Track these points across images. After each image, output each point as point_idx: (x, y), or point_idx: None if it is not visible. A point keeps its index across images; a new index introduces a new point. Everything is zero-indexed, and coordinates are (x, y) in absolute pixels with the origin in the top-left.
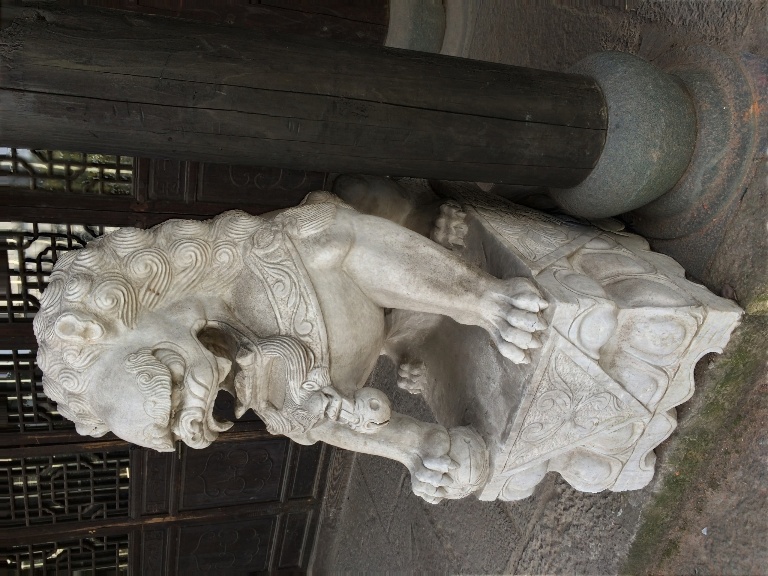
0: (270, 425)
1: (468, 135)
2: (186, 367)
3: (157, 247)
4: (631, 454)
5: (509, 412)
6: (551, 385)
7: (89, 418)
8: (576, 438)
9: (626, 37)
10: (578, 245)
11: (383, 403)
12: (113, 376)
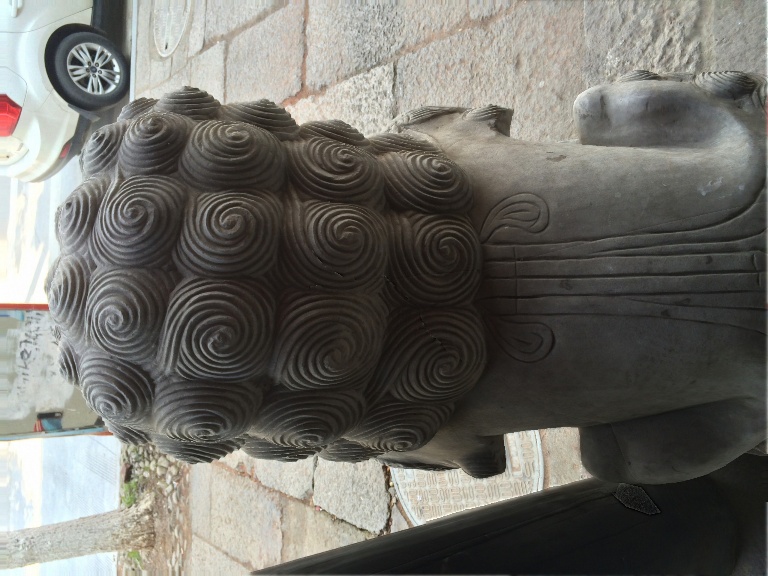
0: None
1: None
2: None
3: None
4: None
5: None
6: None
7: None
8: None
9: None
10: None
11: None
12: None
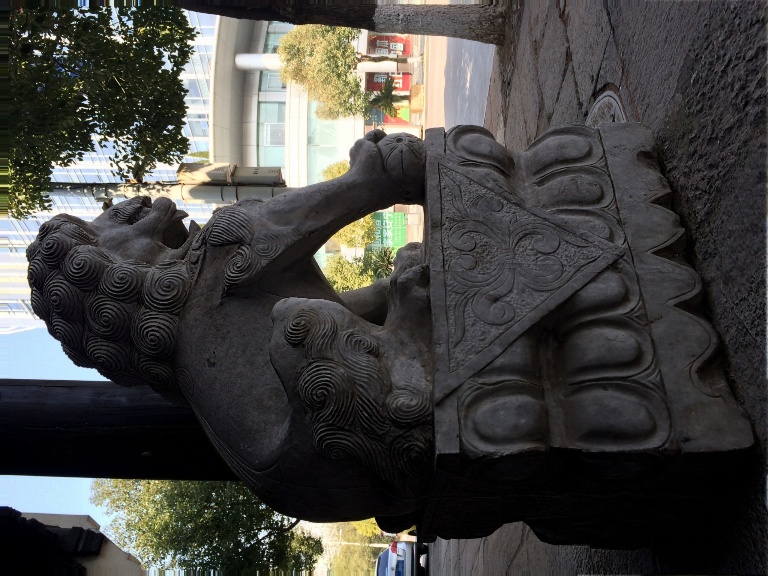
0: None
1: None
2: None
3: None
4: None
5: None
6: None
7: None
8: None
9: (599, 575)
10: None
11: None
12: None
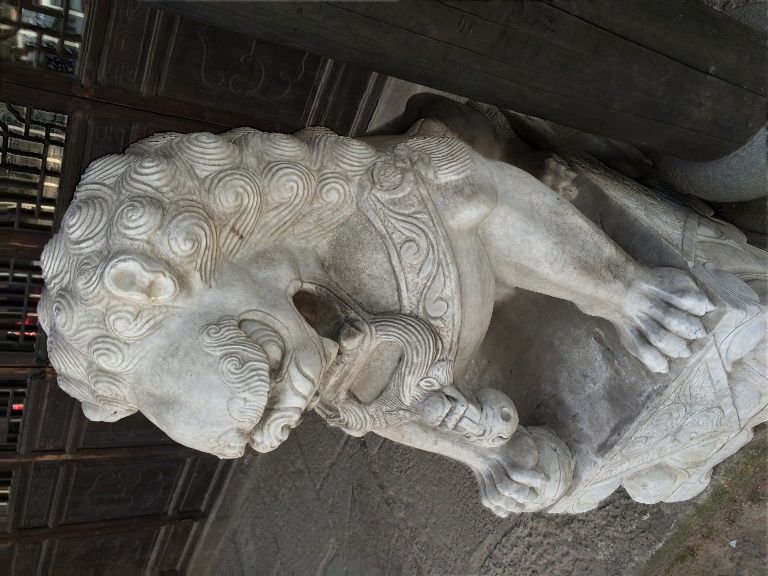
0: (343, 420)
1: (649, 79)
2: (286, 350)
3: (245, 168)
4: (700, 467)
5: (617, 422)
6: (677, 398)
7: (117, 403)
8: (667, 452)
9: None
10: (694, 230)
11: (514, 412)
12: (183, 356)
